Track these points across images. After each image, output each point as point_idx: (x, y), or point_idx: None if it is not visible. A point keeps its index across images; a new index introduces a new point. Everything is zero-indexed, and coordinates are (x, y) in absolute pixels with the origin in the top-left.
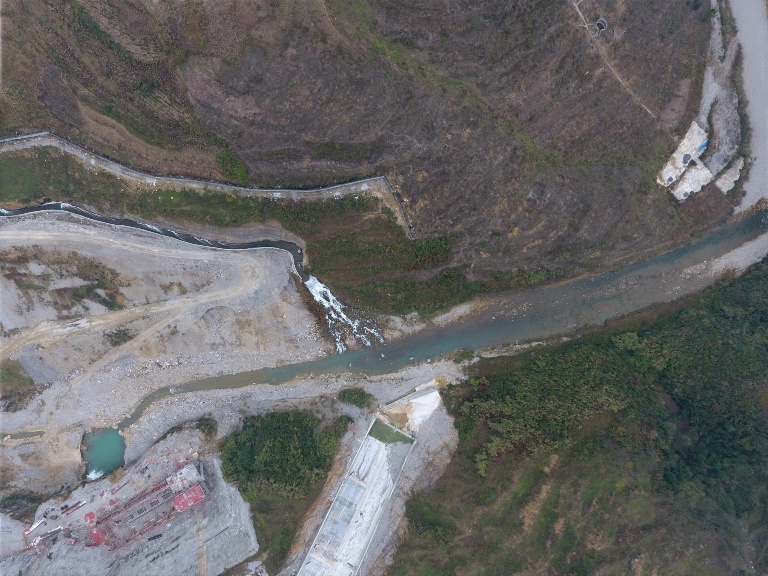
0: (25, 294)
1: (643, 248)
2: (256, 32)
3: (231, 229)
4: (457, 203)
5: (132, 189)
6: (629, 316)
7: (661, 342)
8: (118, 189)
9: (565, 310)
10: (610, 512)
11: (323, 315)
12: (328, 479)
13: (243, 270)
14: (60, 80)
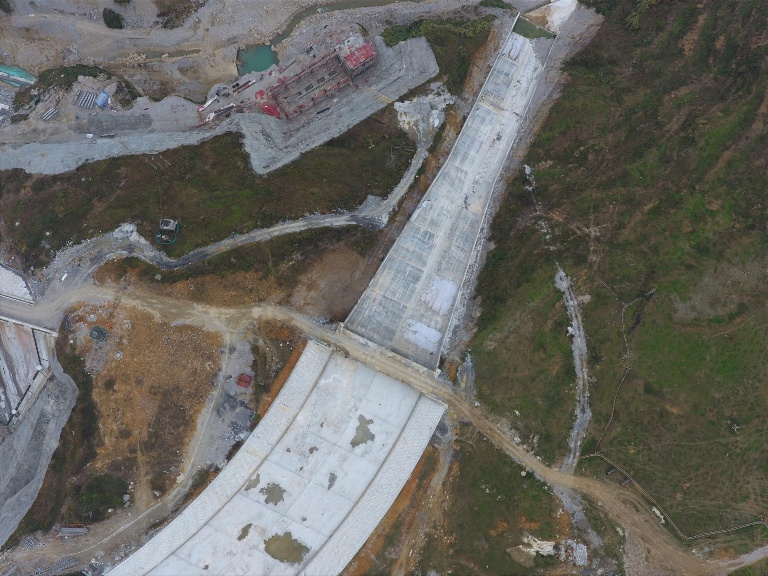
0: None
1: None
2: None
3: None
4: None
5: None
6: None
7: None
8: None
9: None
10: None
11: None
12: (489, 38)
13: None
14: None
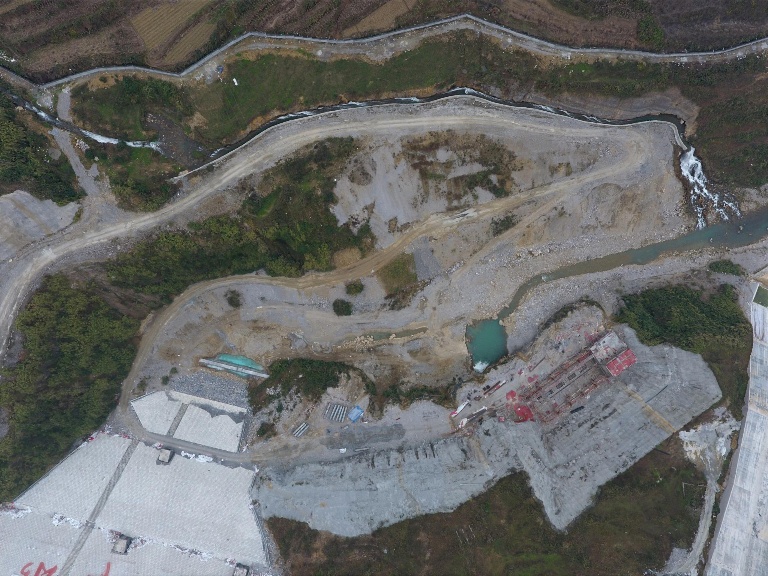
0: (424, 185)
1: None
2: None
3: (631, 100)
4: None
5: (545, 65)
6: None
7: None
8: (531, 67)
9: None
10: None
11: (689, 190)
12: None
13: (629, 145)
14: None
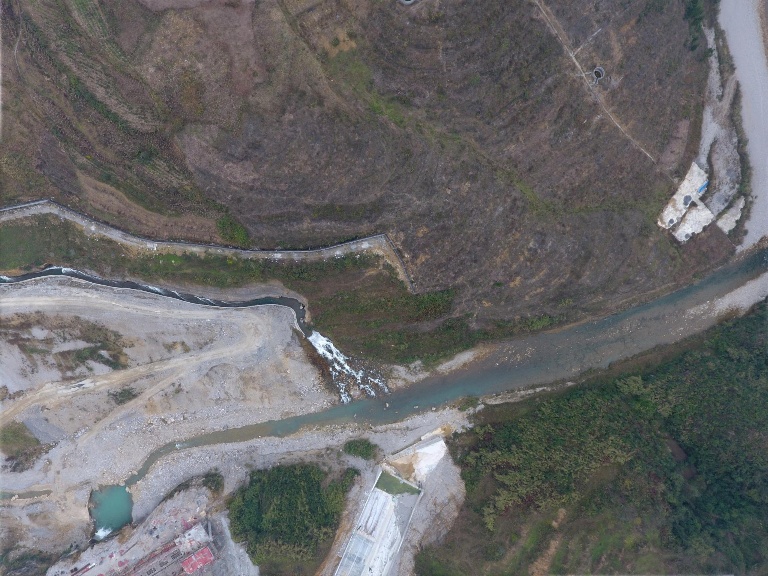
0: (29, 358)
1: (645, 290)
2: (253, 98)
3: (233, 289)
4: (458, 256)
5: (133, 254)
6: (633, 359)
7: (666, 387)
8: (119, 254)
9: (569, 354)
10: (619, 569)
11: (327, 367)
12: (336, 537)
13: (246, 327)
14: (58, 149)
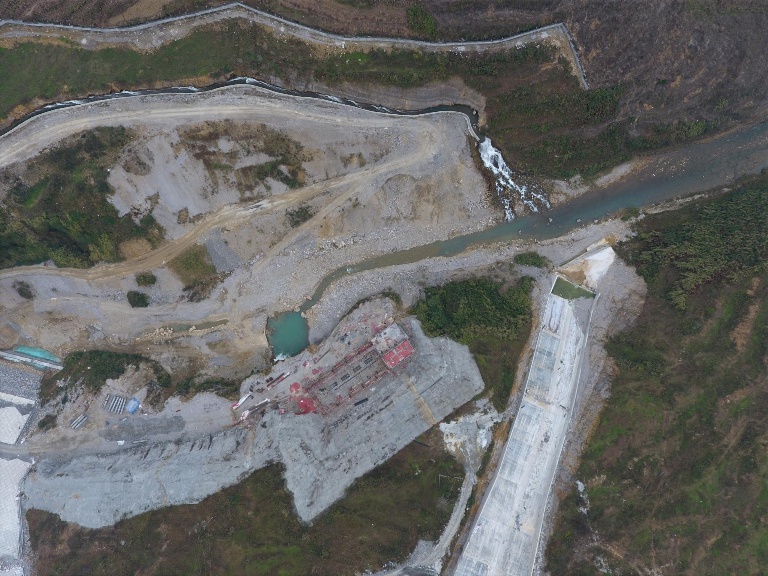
0: (211, 175)
1: None
2: None
3: (414, 90)
4: (625, 52)
5: (320, 54)
6: None
7: None
8: (306, 56)
9: (722, 162)
10: None
11: (493, 181)
12: None
13: (421, 136)
14: None
